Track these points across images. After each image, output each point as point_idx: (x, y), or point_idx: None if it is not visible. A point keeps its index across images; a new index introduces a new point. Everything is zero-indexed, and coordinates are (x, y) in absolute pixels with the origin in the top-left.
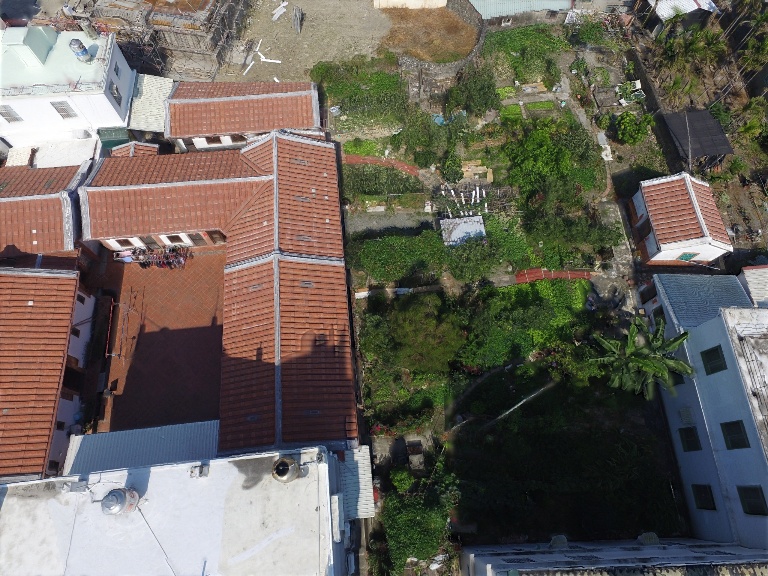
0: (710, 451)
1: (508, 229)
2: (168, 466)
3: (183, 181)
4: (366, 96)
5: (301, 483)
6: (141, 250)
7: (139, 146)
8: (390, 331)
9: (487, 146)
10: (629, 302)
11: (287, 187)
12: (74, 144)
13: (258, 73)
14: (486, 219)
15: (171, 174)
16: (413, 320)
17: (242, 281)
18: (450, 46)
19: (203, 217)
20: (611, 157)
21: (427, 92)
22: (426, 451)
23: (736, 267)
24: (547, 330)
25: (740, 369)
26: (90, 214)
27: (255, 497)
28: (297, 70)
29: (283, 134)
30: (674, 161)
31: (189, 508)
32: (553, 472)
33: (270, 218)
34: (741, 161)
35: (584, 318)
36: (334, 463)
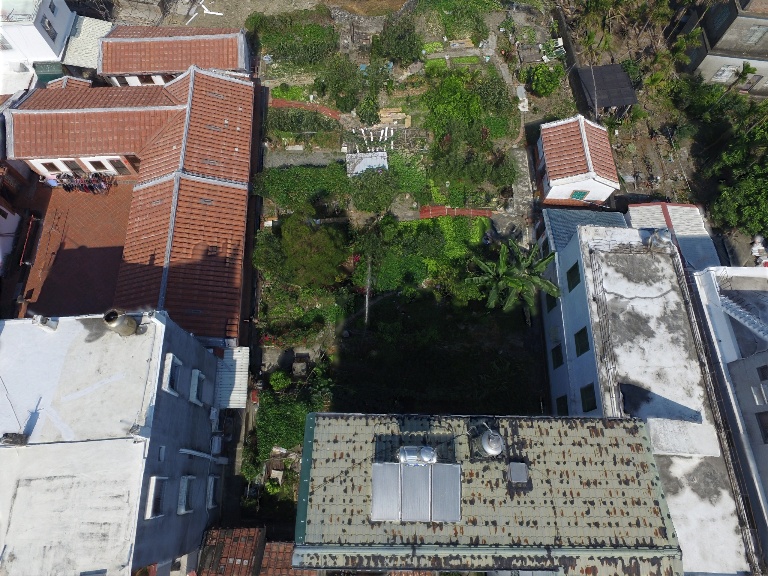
0: (565, 361)
1: (410, 164)
2: (21, 320)
3: (102, 107)
4: (294, 44)
5: (138, 339)
6: (66, 174)
7: (72, 80)
8: (281, 247)
9: (409, 95)
10: (525, 238)
11: (199, 116)
12: (12, 77)
13: (200, 24)
14: (390, 155)
15: (94, 102)
16: (290, 228)
17: (147, 197)
18: (385, 3)
19: (120, 142)
20: (527, 108)
21: (356, 43)
22: (313, 362)
23: (626, 207)
24: (441, 260)
25: (585, 278)
26: (14, 135)
27: (95, 349)
28: (238, 22)
29: (202, 69)
30: (584, 112)
31: (34, 355)
32: (429, 385)
33: (179, 142)
34: (653, 115)
35: (480, 251)
36: (196, 345)
